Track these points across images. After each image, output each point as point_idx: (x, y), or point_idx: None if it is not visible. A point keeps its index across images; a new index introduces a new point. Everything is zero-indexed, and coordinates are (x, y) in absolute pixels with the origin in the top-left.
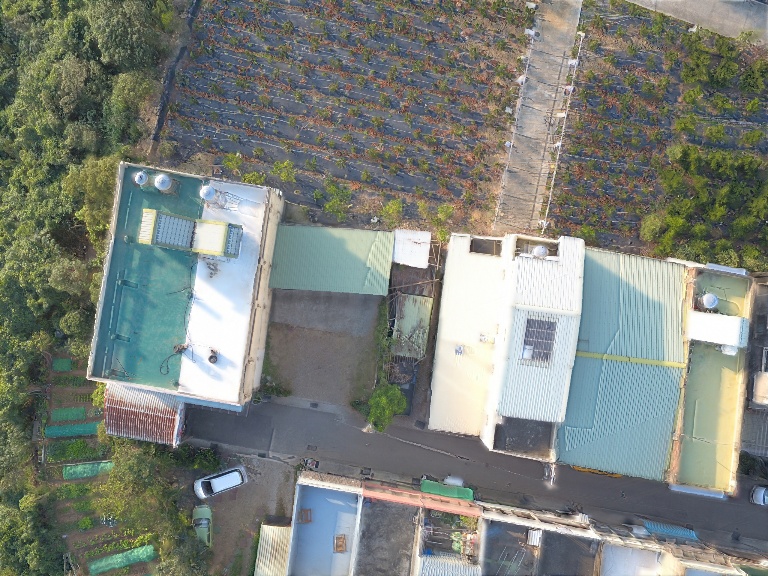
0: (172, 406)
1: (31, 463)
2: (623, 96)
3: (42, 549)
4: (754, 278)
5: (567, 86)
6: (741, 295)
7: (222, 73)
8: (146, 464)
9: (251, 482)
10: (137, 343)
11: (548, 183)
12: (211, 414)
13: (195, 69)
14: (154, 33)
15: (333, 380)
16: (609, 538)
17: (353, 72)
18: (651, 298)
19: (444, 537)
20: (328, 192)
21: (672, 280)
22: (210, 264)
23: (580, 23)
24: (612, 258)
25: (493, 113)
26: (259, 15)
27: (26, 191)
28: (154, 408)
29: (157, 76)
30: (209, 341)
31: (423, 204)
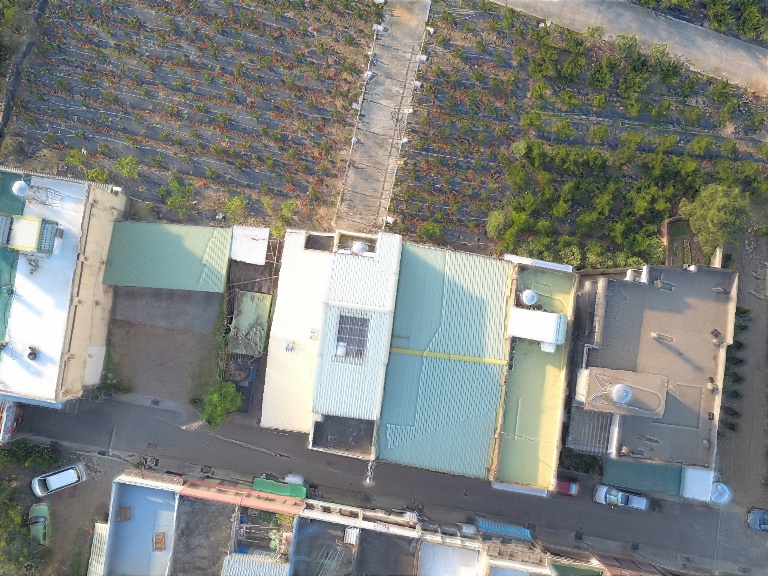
0: None
1: None
2: None
3: None
4: (577, 275)
5: (415, 82)
6: (566, 292)
7: (69, 69)
8: None
9: (91, 480)
10: None
11: (395, 179)
12: (51, 412)
13: (42, 65)
14: None
15: (174, 377)
16: (428, 537)
17: (200, 68)
18: (475, 295)
19: (262, 535)
20: (170, 188)
21: (498, 277)
22: (31, 260)
23: (429, 18)
24: (438, 254)
25: (340, 109)
26: (106, 10)
27: None
28: None
29: (4, 72)
30: (28, 338)
31: (266, 200)
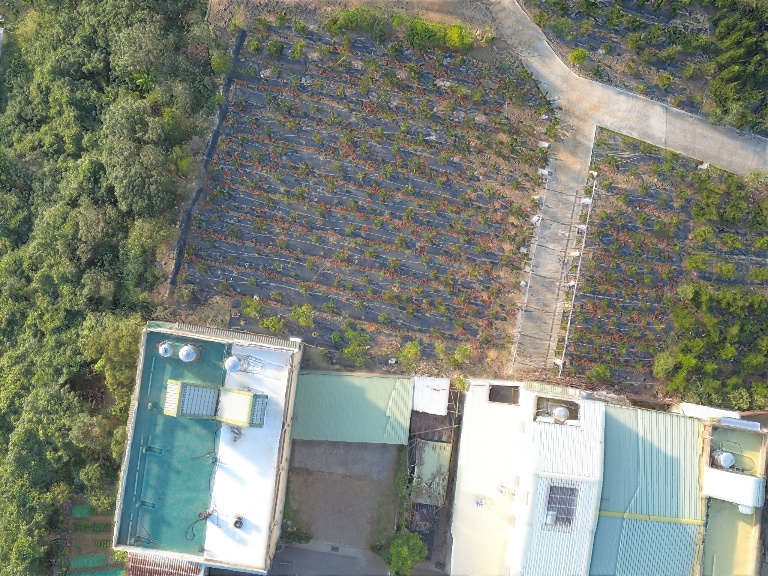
0: (196, 564)
1: None
2: (635, 234)
3: None
4: None
5: (580, 225)
6: (756, 449)
7: (238, 215)
8: None
9: None
10: (162, 509)
11: (563, 322)
12: None
13: (211, 211)
14: (170, 180)
15: (354, 524)
16: None
17: (369, 213)
18: (669, 454)
19: None
20: (346, 336)
21: (689, 435)
22: (234, 428)
23: (592, 162)
24: (630, 414)
25: (508, 253)
26: (274, 157)
27: (42, 334)
28: (178, 566)
29: (173, 218)
30: (234, 506)
31: (440, 346)
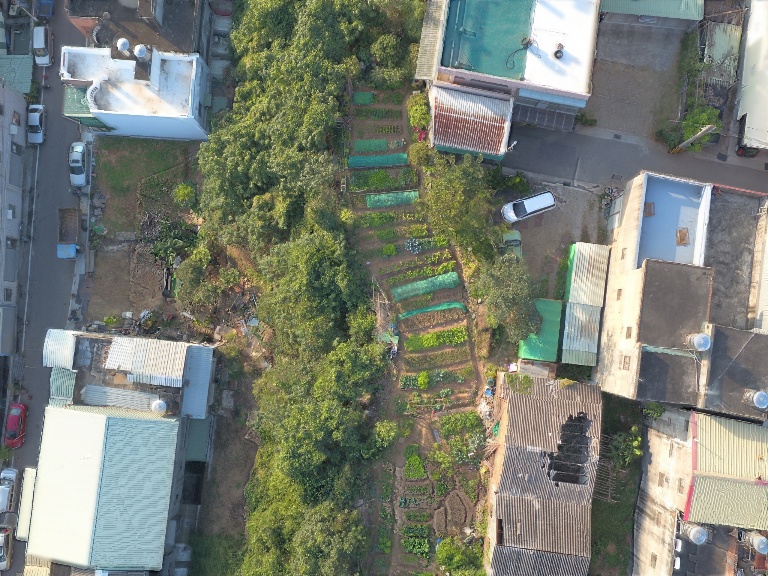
0: (501, 114)
1: None
2: None
3: (350, 272)
4: None
5: None
6: None
7: None
8: (479, 167)
9: (556, 210)
10: (483, 38)
11: None
12: None
13: None
14: None
15: (636, 112)
16: None
17: None
18: None
19: None
20: None
21: None
22: None
23: None
24: None
25: None
26: None
27: None
28: (484, 116)
29: None
30: (556, 35)
31: None
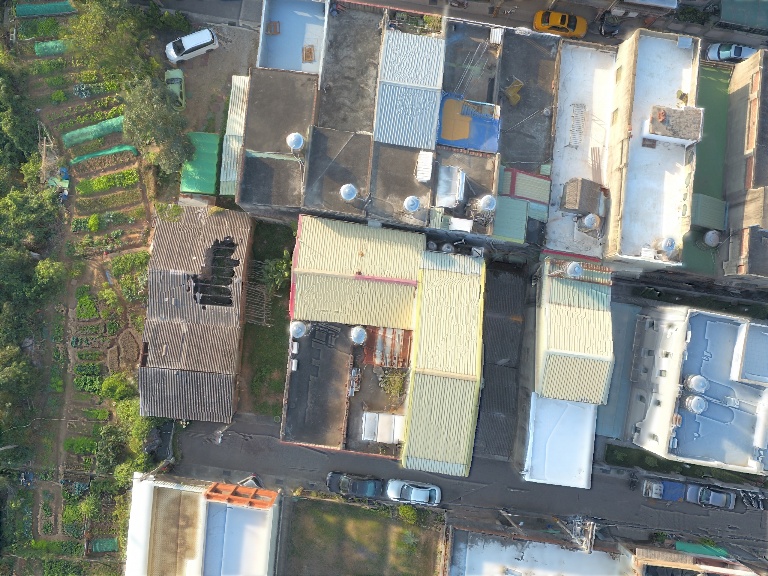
0: None
1: (3, 40)
2: None
3: (16, 118)
4: None
5: None
6: None
7: None
8: None
9: (222, 50)
10: None
11: None
12: None
13: None
14: None
15: None
16: None
17: None
18: None
19: None
20: None
21: None
22: None
23: None
24: None
25: None
26: None
27: None
28: None
29: None
30: None
31: None
